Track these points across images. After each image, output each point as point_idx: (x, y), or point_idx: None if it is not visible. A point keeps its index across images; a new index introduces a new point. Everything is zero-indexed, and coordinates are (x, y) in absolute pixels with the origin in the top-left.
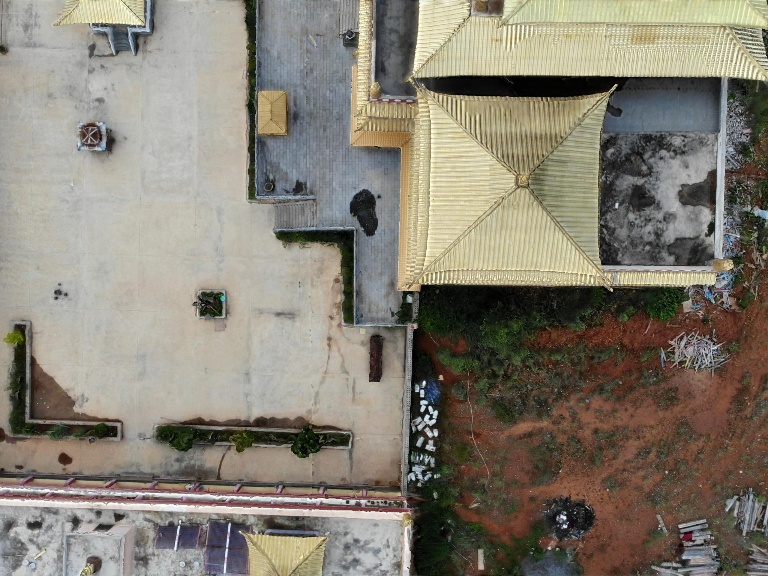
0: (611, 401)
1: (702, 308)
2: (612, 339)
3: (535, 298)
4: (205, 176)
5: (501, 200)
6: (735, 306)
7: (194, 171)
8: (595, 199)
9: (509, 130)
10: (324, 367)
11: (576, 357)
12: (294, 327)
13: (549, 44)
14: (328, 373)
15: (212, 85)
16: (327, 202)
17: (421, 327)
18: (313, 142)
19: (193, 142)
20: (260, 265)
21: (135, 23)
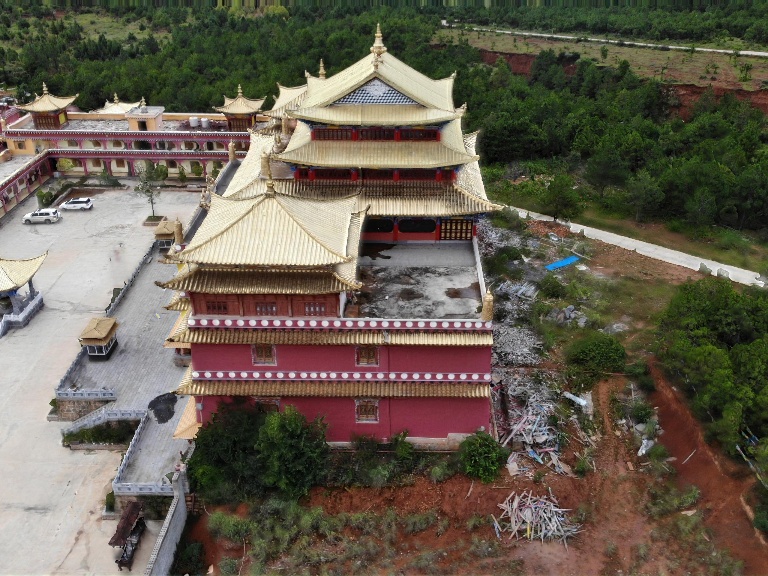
0: (434, 575)
1: (531, 470)
2: (429, 505)
3: (334, 463)
4: (15, 404)
5: (252, 207)
6: (572, 474)
7: (6, 400)
8: (345, 233)
9: None
10: (60, 561)
11: (385, 526)
12: (42, 520)
13: (319, 195)
14: (62, 568)
15: (58, 352)
16: (127, 401)
17: (193, 485)
18: (132, 365)
19: (18, 383)
20: (32, 467)
21: (11, 287)
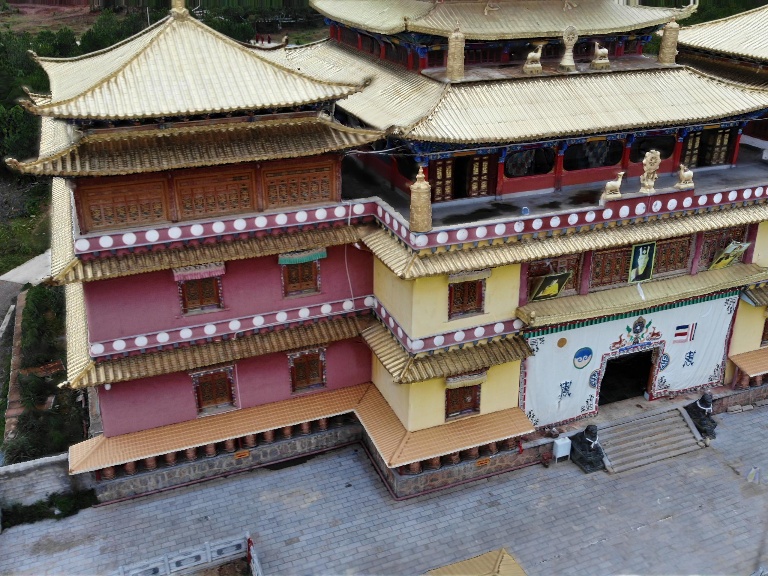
0: None
1: None
2: None
3: None
4: None
5: None
6: None
7: None
8: None
9: (764, 32)
10: None
11: None
12: None
13: None
14: None
15: None
16: None
17: None
18: None
19: None
20: None
21: None
